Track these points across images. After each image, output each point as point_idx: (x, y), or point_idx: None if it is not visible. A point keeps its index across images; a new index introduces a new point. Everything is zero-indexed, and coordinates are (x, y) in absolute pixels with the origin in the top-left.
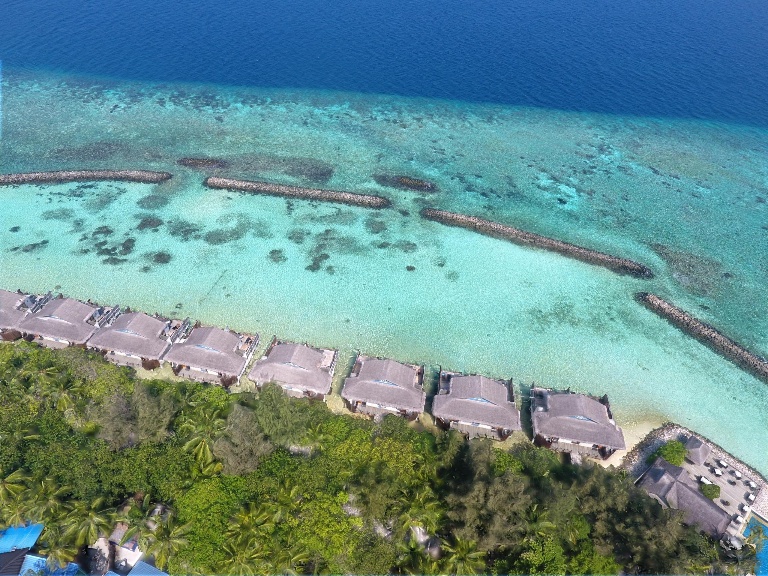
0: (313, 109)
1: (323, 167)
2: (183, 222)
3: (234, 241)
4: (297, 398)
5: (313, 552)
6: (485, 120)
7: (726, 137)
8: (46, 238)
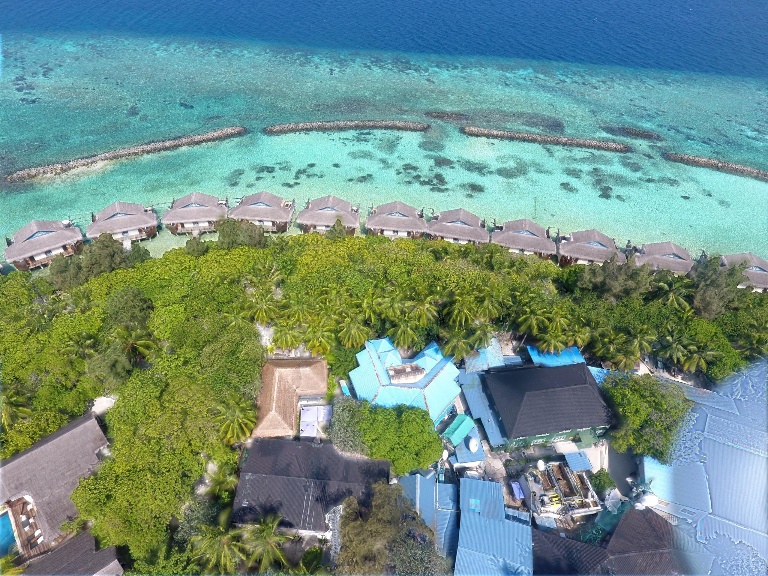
0: (504, 73)
1: (552, 120)
2: (469, 161)
3: (524, 176)
4: None
5: None
6: (662, 83)
7: None
8: (368, 172)
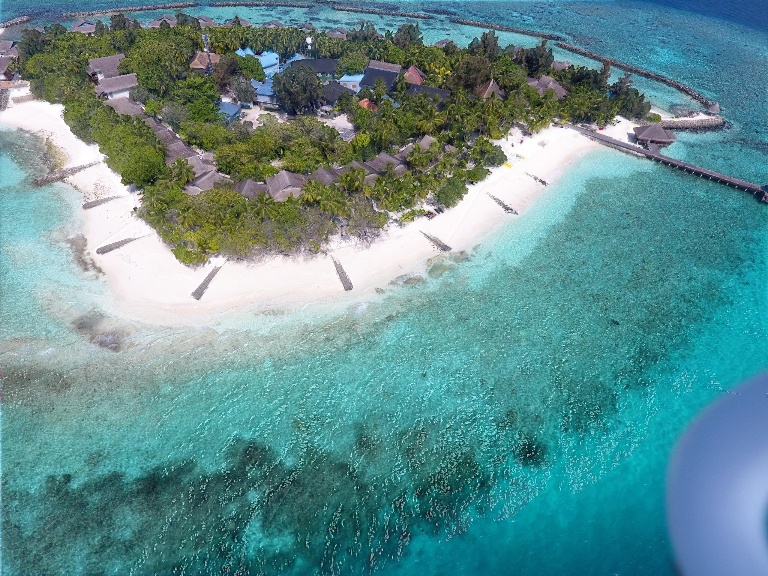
0: None
1: (393, 6)
2: (331, 19)
3: None
4: None
5: (433, 52)
6: None
7: (626, 4)
8: (268, 21)
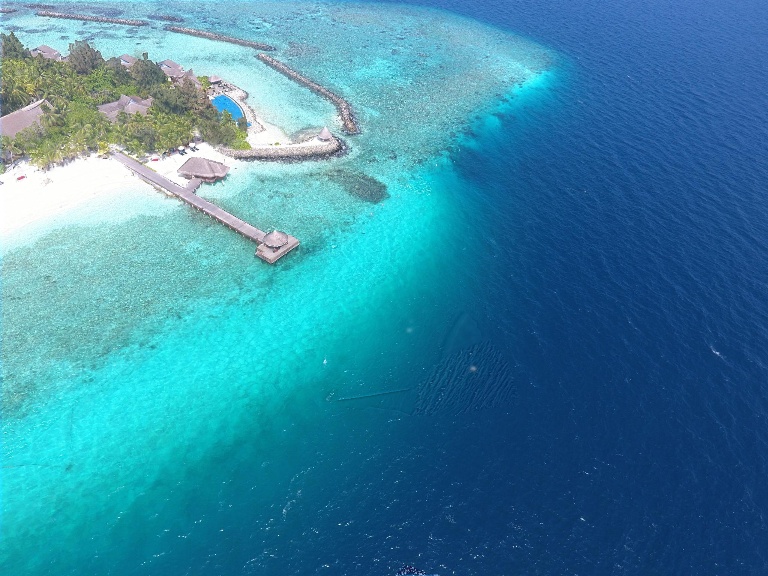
0: None
1: (118, 11)
2: (15, 26)
3: (42, 33)
4: None
5: (8, 66)
6: None
7: (405, 10)
8: None
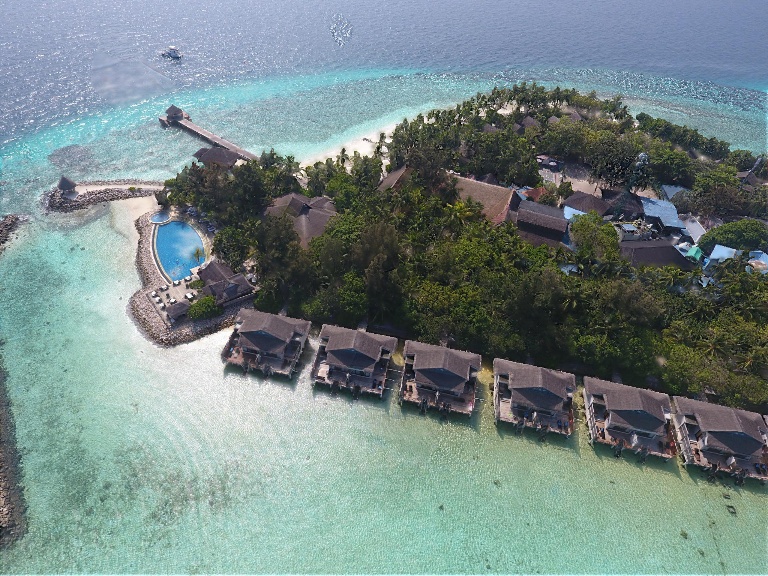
0: None
1: None
2: None
3: None
4: (520, 348)
5: None
6: None
7: None
8: None
